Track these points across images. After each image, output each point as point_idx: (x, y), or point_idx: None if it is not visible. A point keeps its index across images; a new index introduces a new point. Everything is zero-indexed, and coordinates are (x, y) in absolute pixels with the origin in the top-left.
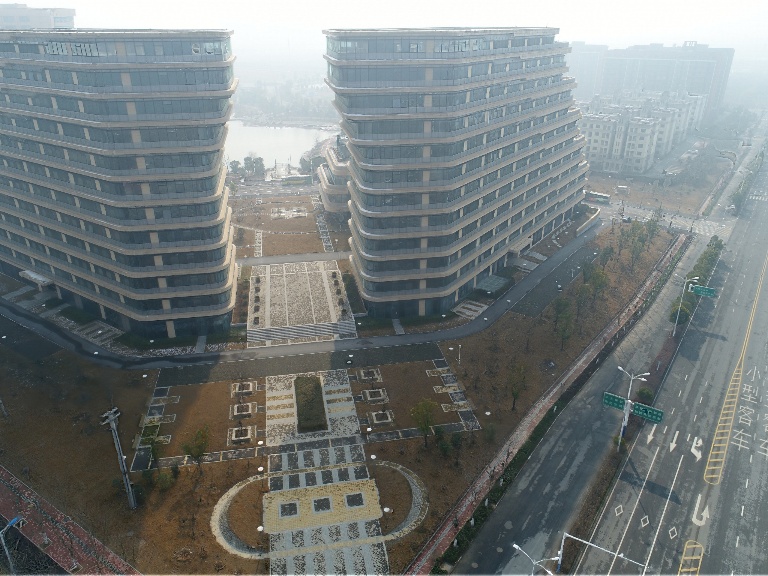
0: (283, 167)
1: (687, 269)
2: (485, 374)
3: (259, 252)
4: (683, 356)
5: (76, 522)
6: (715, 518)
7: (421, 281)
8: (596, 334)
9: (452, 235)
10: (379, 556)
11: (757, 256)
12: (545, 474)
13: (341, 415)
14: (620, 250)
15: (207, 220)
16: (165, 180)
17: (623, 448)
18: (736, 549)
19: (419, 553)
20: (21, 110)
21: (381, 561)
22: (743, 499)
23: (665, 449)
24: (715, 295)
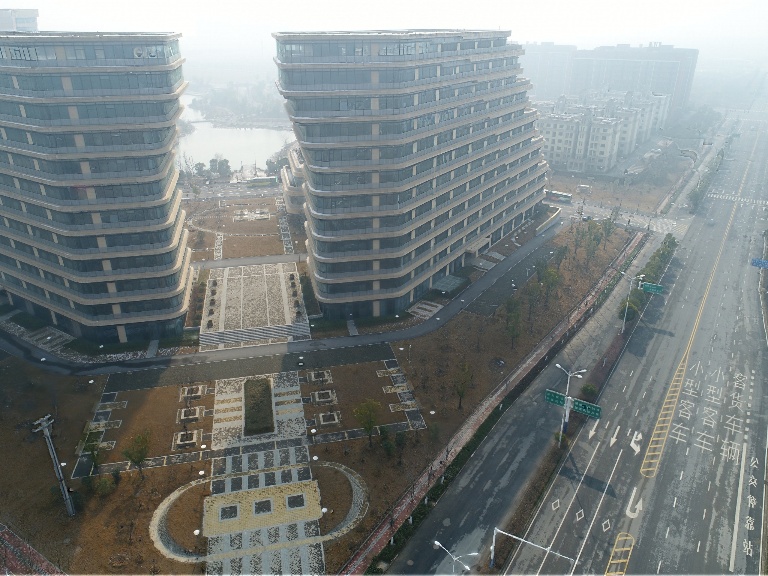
0: (250, 169)
1: (641, 267)
2: (435, 373)
3: (219, 255)
4: (630, 352)
5: (12, 531)
6: (648, 510)
7: (374, 282)
8: (547, 332)
9: (404, 236)
10: (316, 556)
11: (710, 253)
12: (486, 471)
13: (289, 417)
14: (576, 249)
15: (155, 224)
16: (111, 184)
17: (564, 444)
18: (665, 540)
19: (356, 552)
20: None
21: (317, 561)
22: (676, 491)
23: (605, 444)
24: (666, 292)
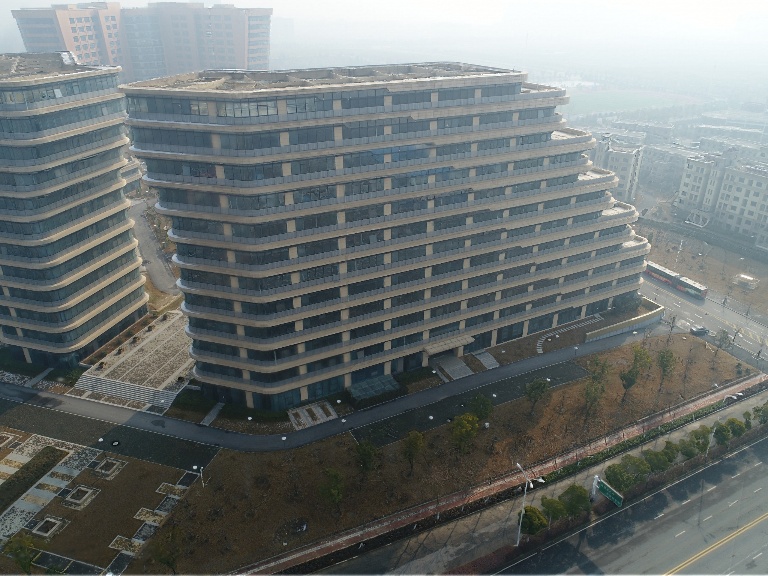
0: None
1: None
2: (209, 513)
3: None
4: None
5: None
6: None
7: (244, 370)
8: (416, 502)
9: (278, 327)
10: None
11: None
12: None
13: (26, 507)
14: None
15: (37, 262)
16: None
17: None
18: None
19: None
20: None
21: None
22: None
23: None
24: (684, 496)
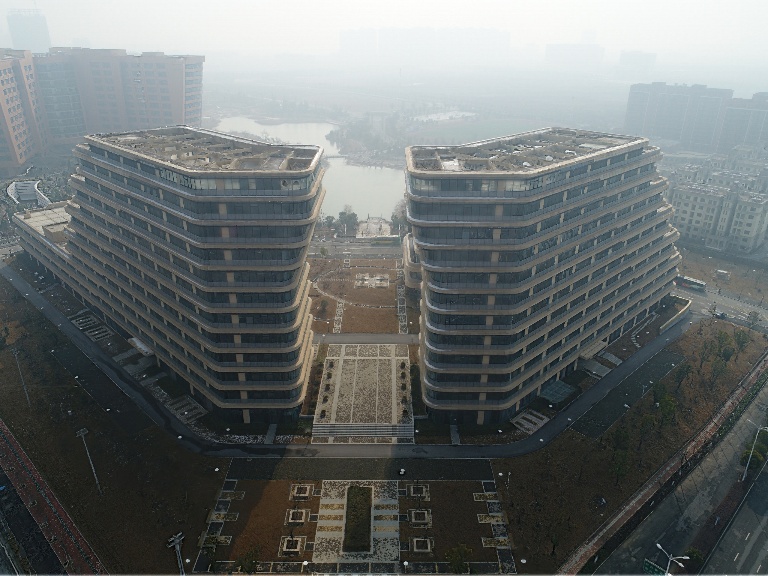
0: (375, 221)
1: None
2: (531, 506)
3: (338, 327)
4: (750, 507)
5: None
6: None
7: (481, 393)
8: (657, 467)
9: (515, 353)
10: None
11: None
12: None
13: (385, 536)
14: (702, 362)
15: (284, 327)
16: (250, 292)
17: None
18: None
19: None
20: (139, 214)
21: None
22: None
23: None
24: None
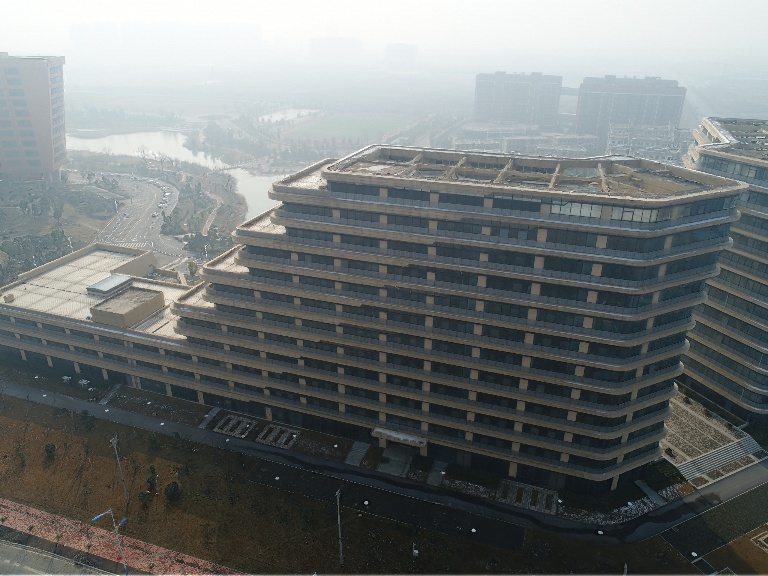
0: None
1: None
2: None
3: None
4: None
5: None
6: None
7: None
8: None
9: None
10: None
11: None
12: None
13: None
14: None
15: (678, 367)
16: None
17: None
18: None
19: None
20: (466, 266)
21: None
22: None
23: None
24: None
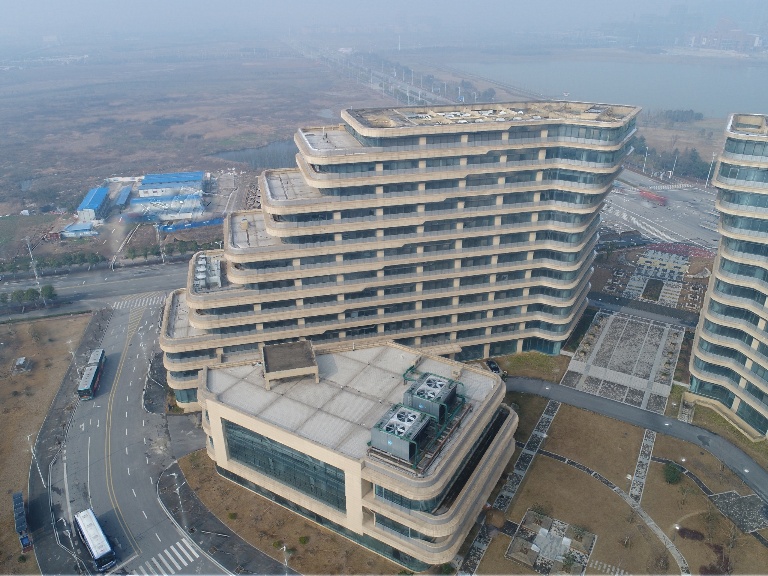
0: None
1: None
2: None
3: (648, 439)
4: None
5: None
6: None
7: None
8: None
9: None
10: None
11: None
12: None
13: None
14: None
15: None
16: None
17: None
18: None
19: None
20: None
21: None
22: None
23: None
24: None
